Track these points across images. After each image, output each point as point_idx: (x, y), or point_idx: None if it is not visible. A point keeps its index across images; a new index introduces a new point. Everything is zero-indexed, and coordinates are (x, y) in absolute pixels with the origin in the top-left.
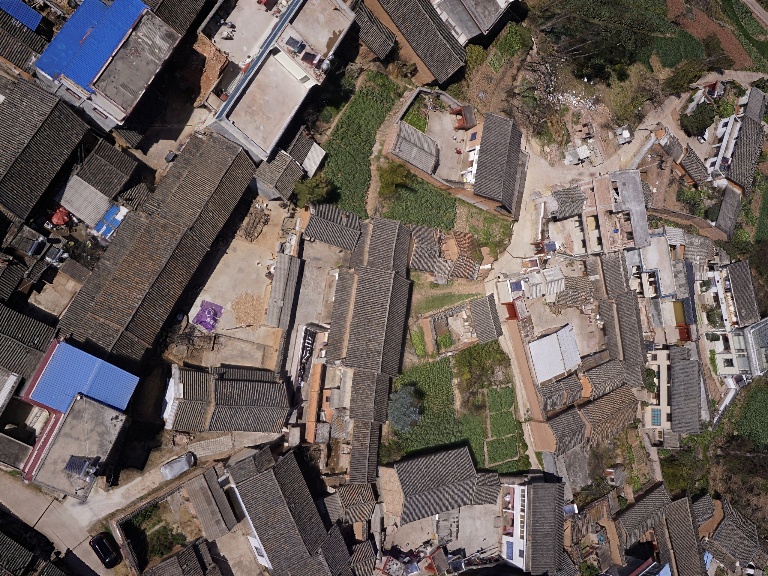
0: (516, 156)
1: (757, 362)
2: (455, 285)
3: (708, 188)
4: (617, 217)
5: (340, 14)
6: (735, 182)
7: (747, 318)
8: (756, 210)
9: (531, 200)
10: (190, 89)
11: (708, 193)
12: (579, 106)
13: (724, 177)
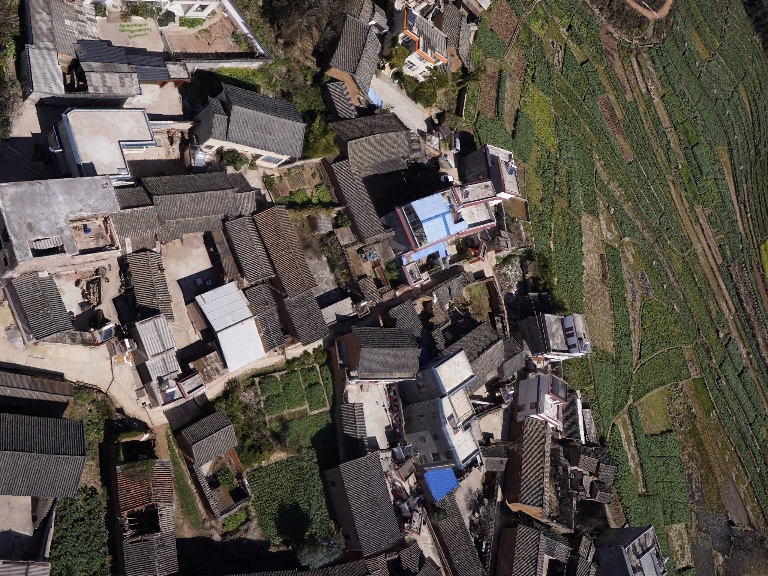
0: None
1: None
2: None
3: None
4: None
5: None
6: None
7: None
8: None
9: (25, 348)
10: None
11: None
12: None
13: None
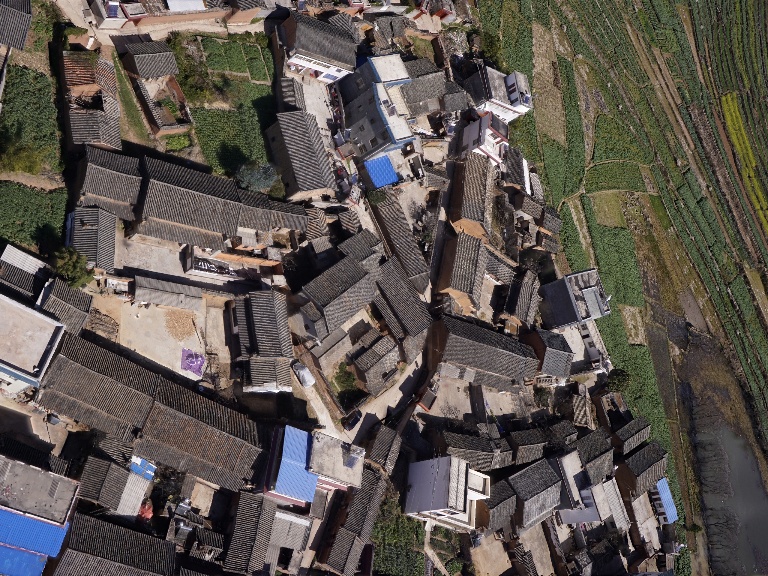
0: None
1: None
2: None
3: None
4: None
5: None
6: None
7: None
8: None
9: None
10: None
11: None
12: None
13: None
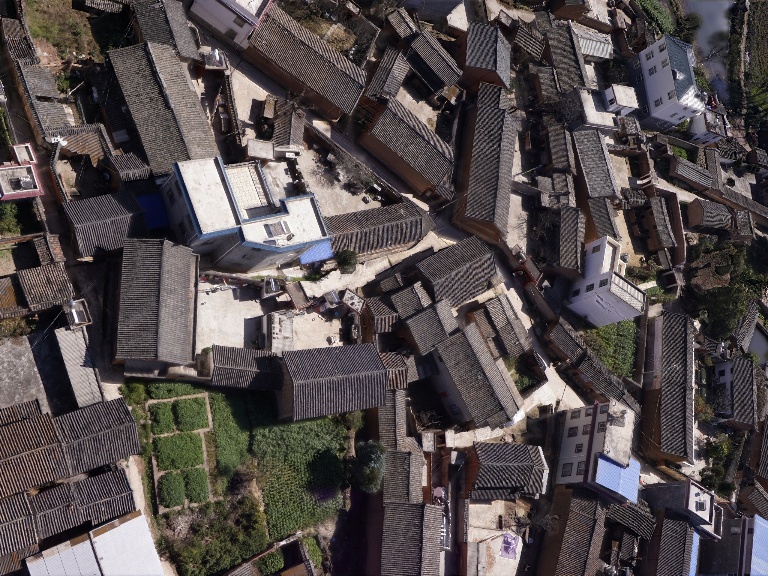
0: None
1: None
2: None
3: None
4: None
5: None
6: None
7: None
8: None
9: None
10: None
11: None
12: None
13: None
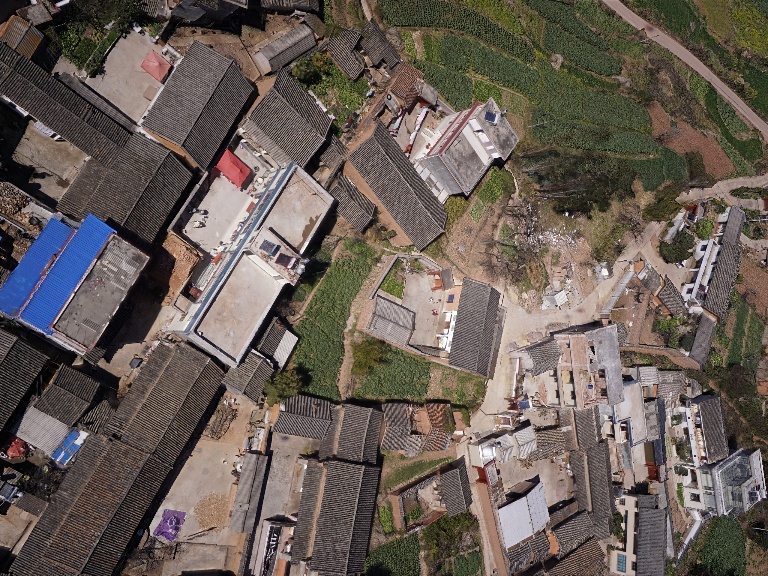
0: (493, 319)
1: (723, 502)
2: (426, 452)
3: (684, 315)
4: (592, 372)
5: (318, 198)
6: (711, 311)
7: (716, 454)
8: (730, 331)
9: (506, 353)
10: (158, 290)
11: (683, 319)
12: (559, 244)
13: (700, 306)
